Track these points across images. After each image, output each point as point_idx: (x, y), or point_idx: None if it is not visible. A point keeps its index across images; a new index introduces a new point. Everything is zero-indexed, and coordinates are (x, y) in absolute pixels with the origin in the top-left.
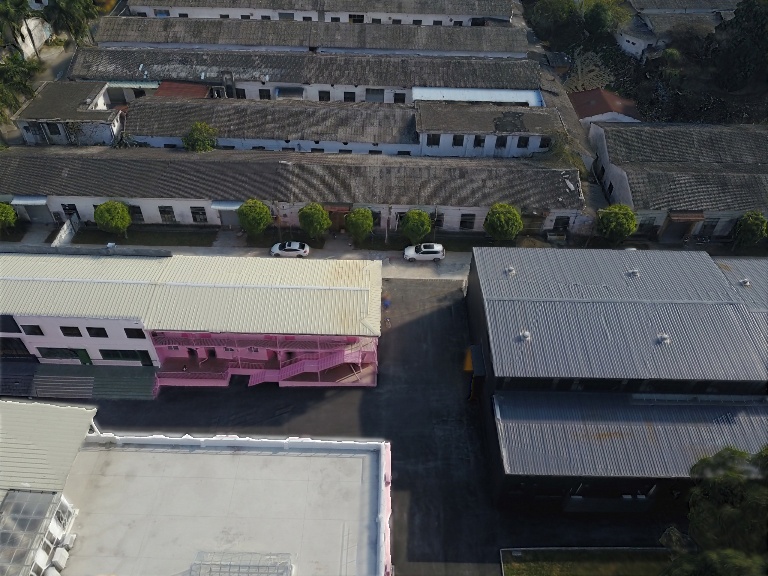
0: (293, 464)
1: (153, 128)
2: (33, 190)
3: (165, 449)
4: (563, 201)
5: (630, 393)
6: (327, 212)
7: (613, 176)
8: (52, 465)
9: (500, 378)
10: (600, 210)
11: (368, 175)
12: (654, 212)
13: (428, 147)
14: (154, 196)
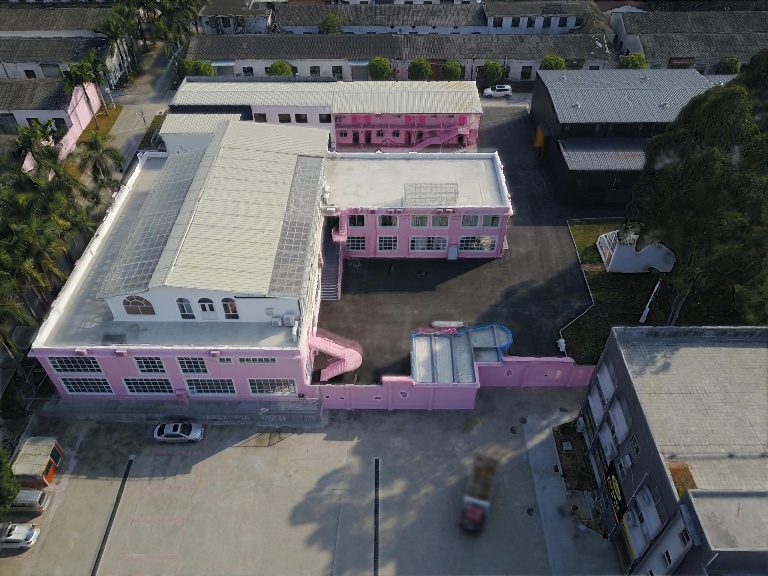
0: (443, 164)
1: (296, 21)
2: (225, 56)
3: (366, 160)
4: (594, 54)
5: (644, 138)
6: (429, 64)
7: (629, 44)
8: (316, 148)
9: (563, 124)
10: (621, 56)
11: (455, 42)
12: (659, 60)
13: (494, 28)
14: (309, 58)
